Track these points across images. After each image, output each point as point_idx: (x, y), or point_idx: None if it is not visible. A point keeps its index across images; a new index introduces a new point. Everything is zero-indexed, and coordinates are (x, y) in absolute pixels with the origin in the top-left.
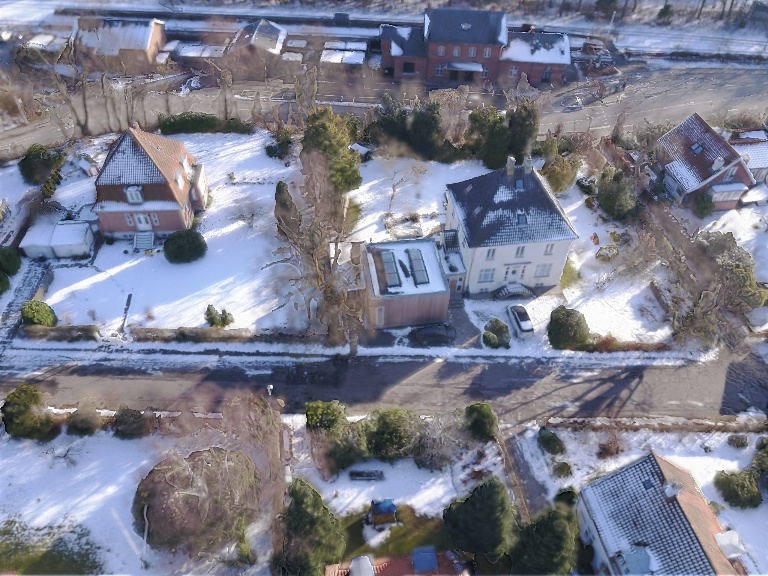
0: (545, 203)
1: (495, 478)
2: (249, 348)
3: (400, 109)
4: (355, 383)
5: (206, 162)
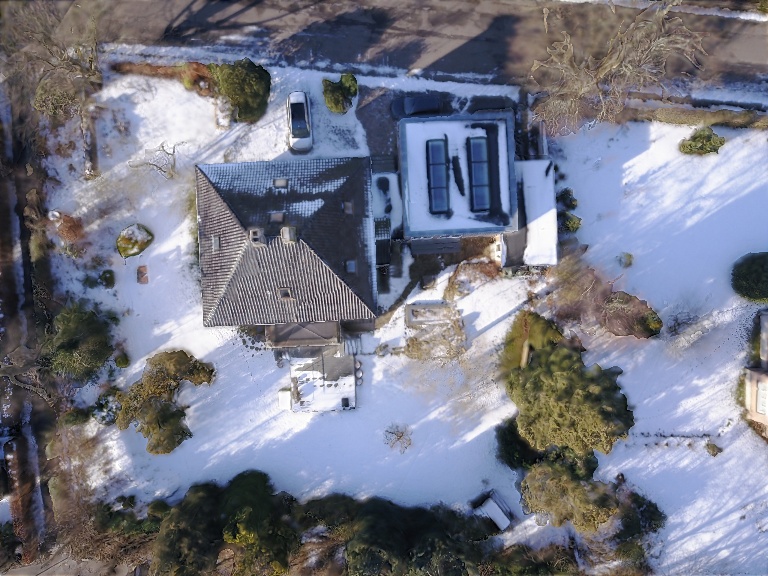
0: (238, 200)
1: None
2: (656, 105)
3: (427, 574)
4: (525, 43)
5: (760, 495)
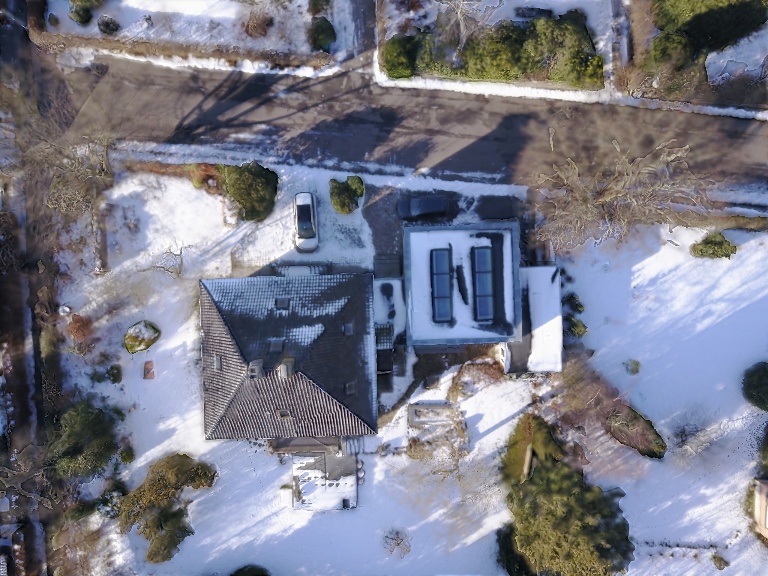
0: (240, 323)
1: (394, 1)
2: None
3: None
4: (534, 143)
5: None
